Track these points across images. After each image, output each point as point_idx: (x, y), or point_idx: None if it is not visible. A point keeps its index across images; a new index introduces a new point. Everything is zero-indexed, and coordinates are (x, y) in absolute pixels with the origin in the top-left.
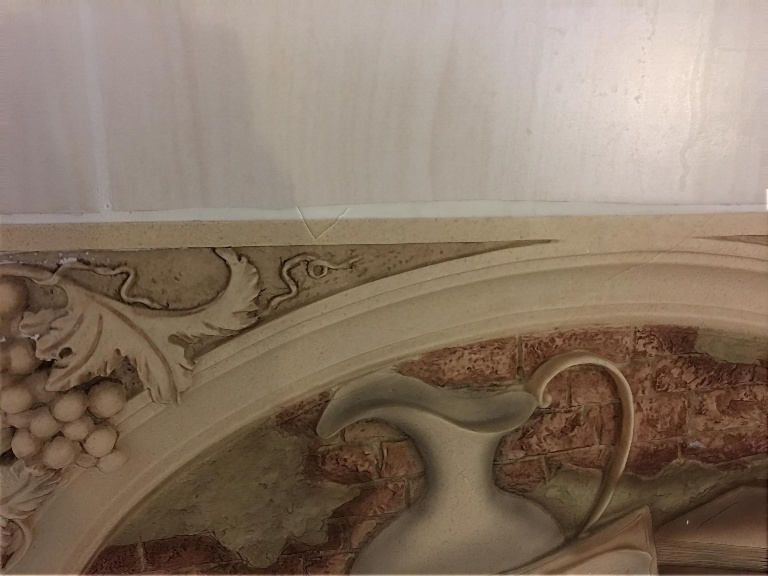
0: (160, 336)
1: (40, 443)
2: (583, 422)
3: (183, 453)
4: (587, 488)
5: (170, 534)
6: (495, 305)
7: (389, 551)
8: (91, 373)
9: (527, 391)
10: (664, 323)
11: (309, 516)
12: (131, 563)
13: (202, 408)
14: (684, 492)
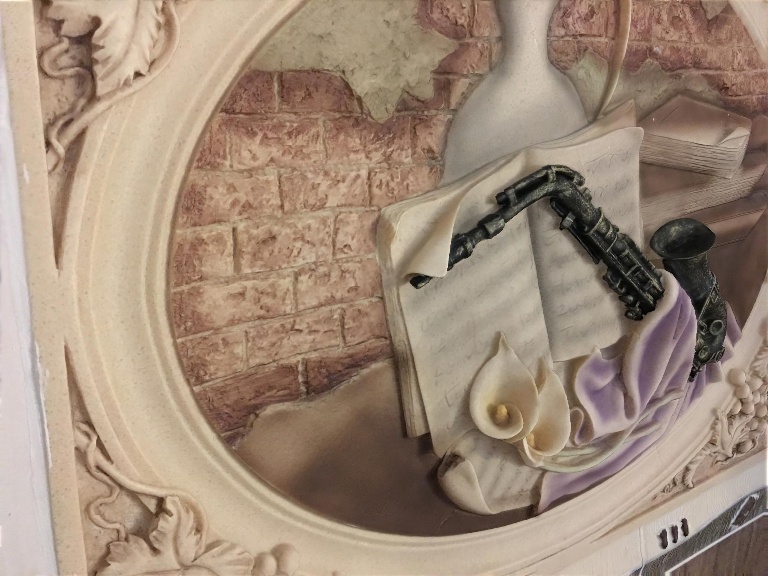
0: None
1: None
2: (597, 13)
3: None
4: (600, 75)
5: (307, 64)
6: None
7: (481, 109)
8: None
9: None
10: None
11: (421, 65)
12: (268, 98)
13: None
14: (651, 91)
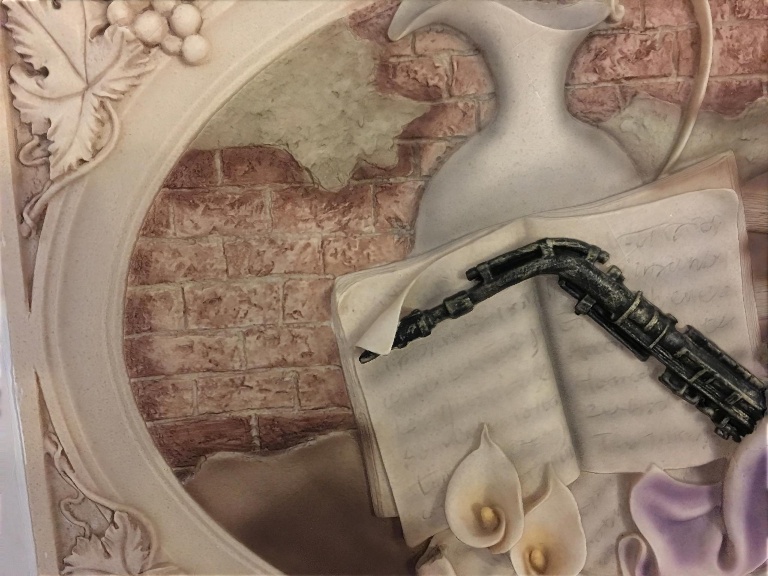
0: None
1: (132, 13)
2: (659, 48)
3: (261, 55)
4: (665, 124)
5: (246, 141)
6: None
7: (459, 174)
8: None
9: (599, 1)
10: None
11: (380, 132)
12: (209, 174)
13: (280, 8)
14: None
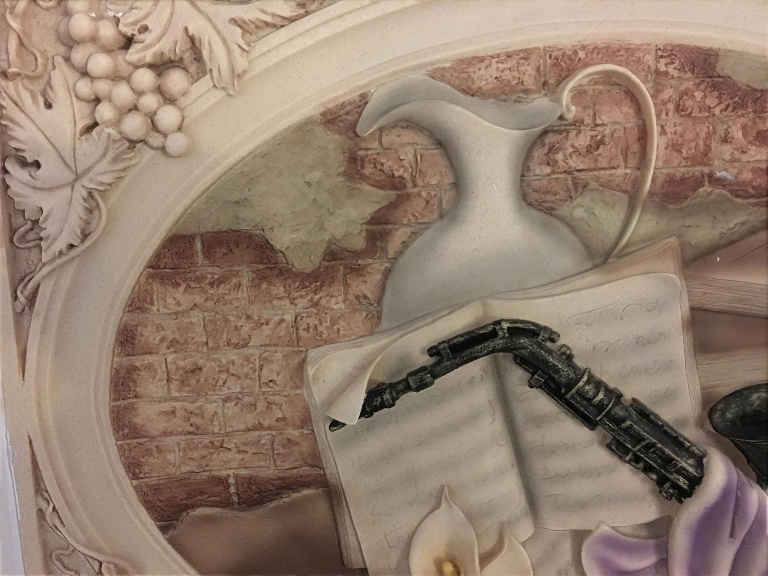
0: (222, 19)
1: (118, 113)
2: (608, 142)
3: (238, 148)
4: (614, 212)
5: (225, 227)
6: (520, 16)
7: (422, 258)
8: (163, 53)
9: (552, 101)
10: (685, 43)
11: (349, 218)
12: (190, 256)
13: (256, 105)
14: (713, 226)
